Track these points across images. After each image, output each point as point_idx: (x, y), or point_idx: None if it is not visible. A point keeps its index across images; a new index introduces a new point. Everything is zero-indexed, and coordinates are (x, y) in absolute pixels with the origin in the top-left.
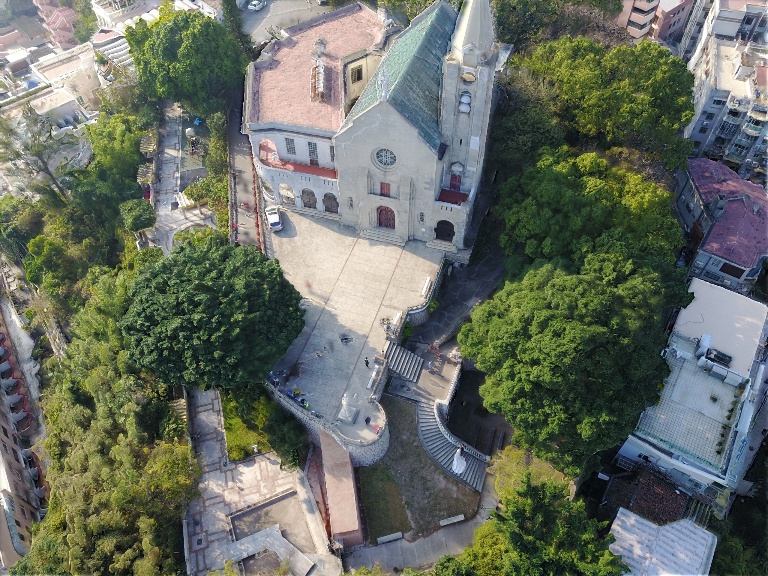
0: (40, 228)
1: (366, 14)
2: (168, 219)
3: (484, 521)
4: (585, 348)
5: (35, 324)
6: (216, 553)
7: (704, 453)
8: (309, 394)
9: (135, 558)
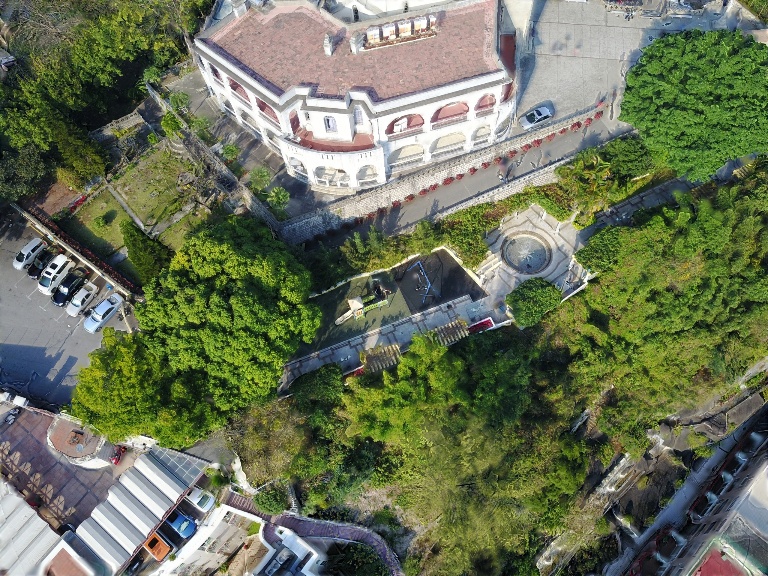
0: (486, 564)
1: (217, 34)
2: (504, 292)
3: (708, 0)
4: None
5: (594, 539)
6: None
7: None
8: None
9: None
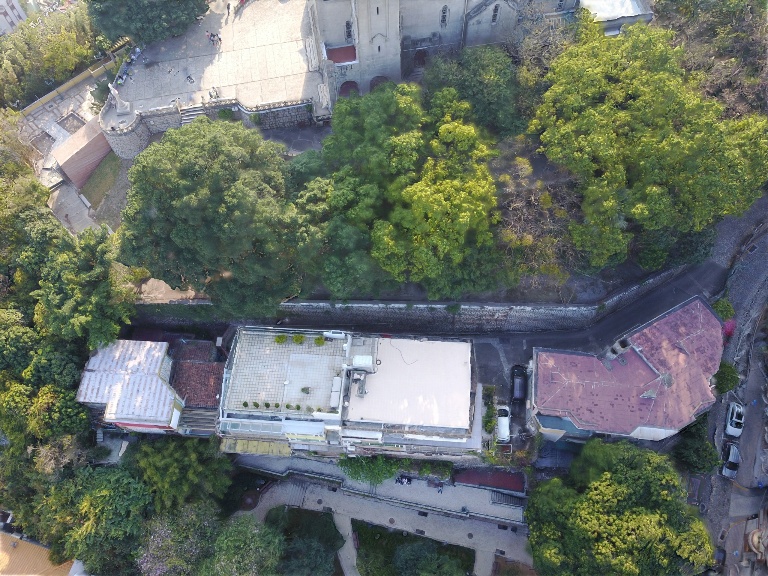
0: None
1: None
2: None
3: None
4: (146, 172)
5: None
6: (46, 118)
7: (242, 394)
8: (132, 81)
9: (5, 68)
